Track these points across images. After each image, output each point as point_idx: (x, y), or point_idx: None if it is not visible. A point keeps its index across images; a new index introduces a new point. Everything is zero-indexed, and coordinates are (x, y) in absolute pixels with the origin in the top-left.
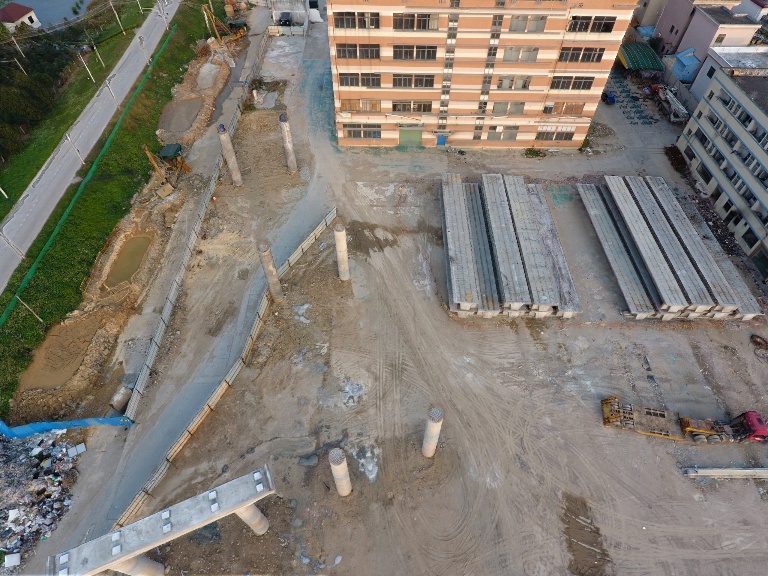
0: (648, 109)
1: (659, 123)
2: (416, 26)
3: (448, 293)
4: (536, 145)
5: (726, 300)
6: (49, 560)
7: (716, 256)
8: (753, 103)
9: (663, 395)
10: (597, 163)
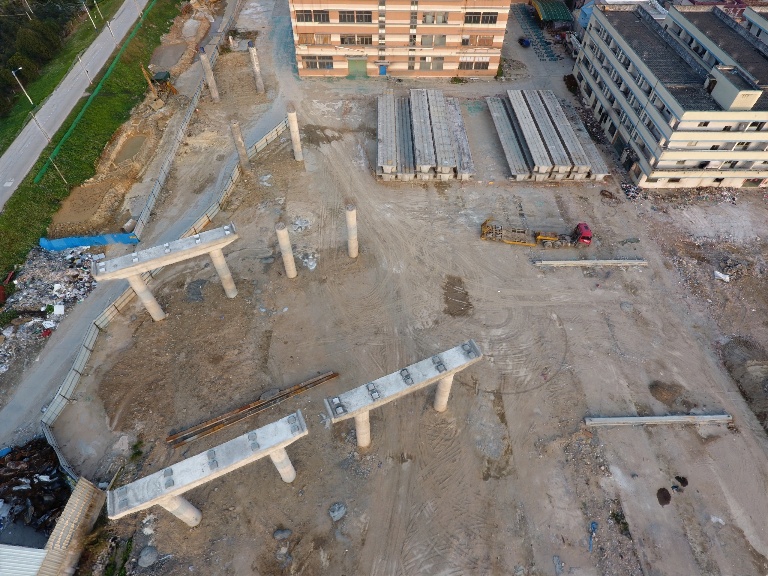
0: (557, 50)
1: (563, 60)
2: None
3: (376, 164)
4: (460, 74)
5: (581, 163)
6: (93, 263)
7: (584, 141)
8: (612, 26)
9: (528, 224)
10: (508, 87)
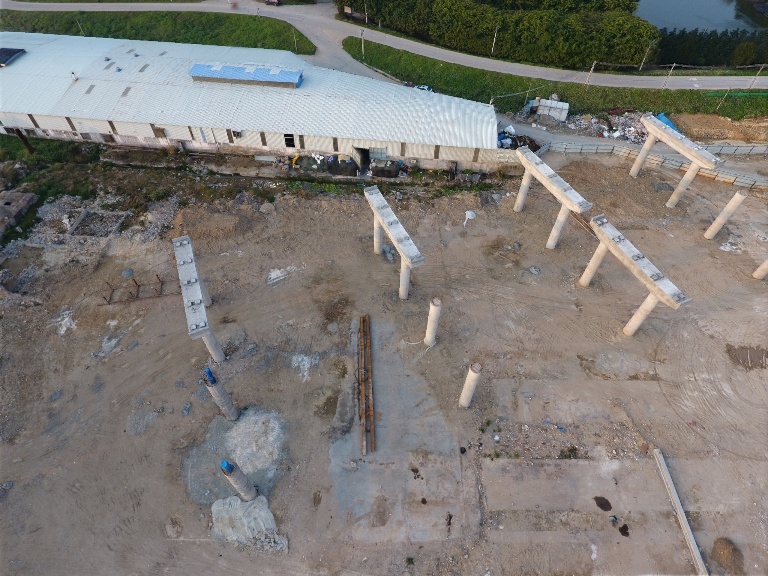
0: None
1: None
2: None
3: None
4: None
5: None
6: None
7: None
8: None
9: None
10: None
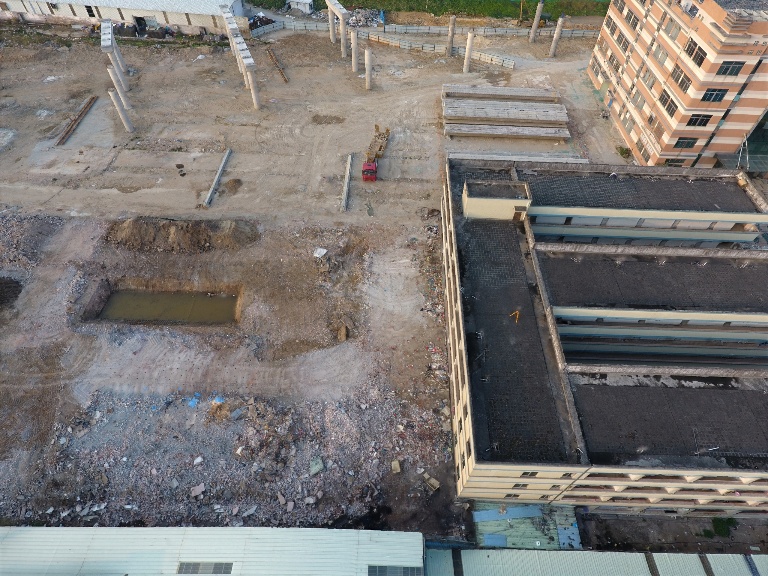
0: None
1: None
2: None
3: None
4: (634, 150)
5: None
6: None
7: None
8: None
9: (394, 159)
10: None
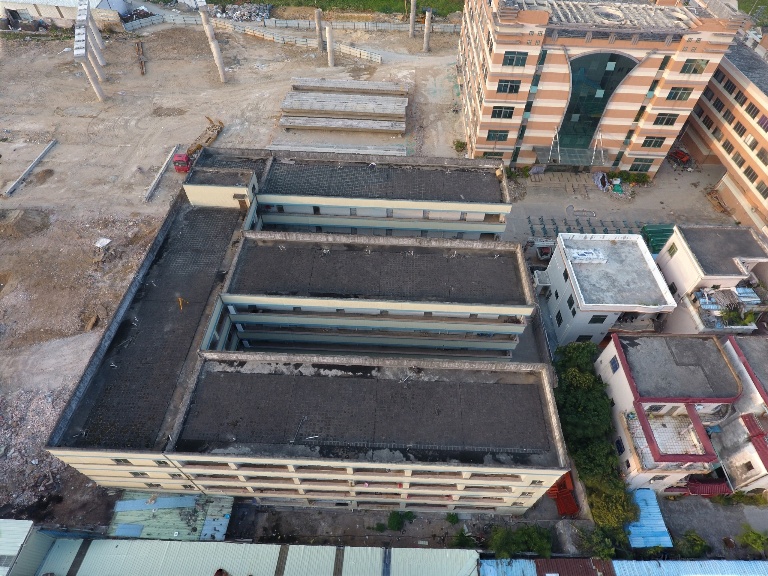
0: None
1: None
2: None
3: None
4: None
5: None
6: None
7: None
8: None
9: None
10: None
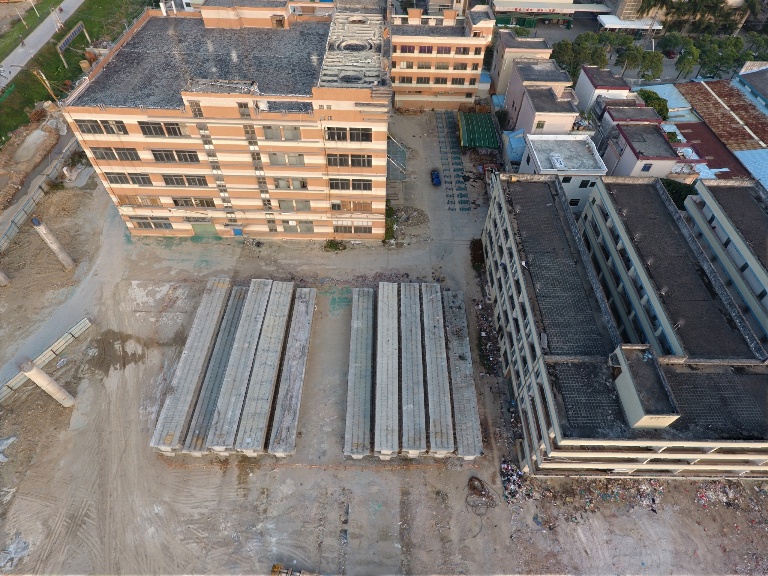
0: (474, 192)
1: (479, 209)
2: (167, 133)
3: None
4: (337, 237)
5: (440, 443)
6: None
7: (462, 381)
8: (509, 221)
9: (347, 555)
10: (395, 258)
